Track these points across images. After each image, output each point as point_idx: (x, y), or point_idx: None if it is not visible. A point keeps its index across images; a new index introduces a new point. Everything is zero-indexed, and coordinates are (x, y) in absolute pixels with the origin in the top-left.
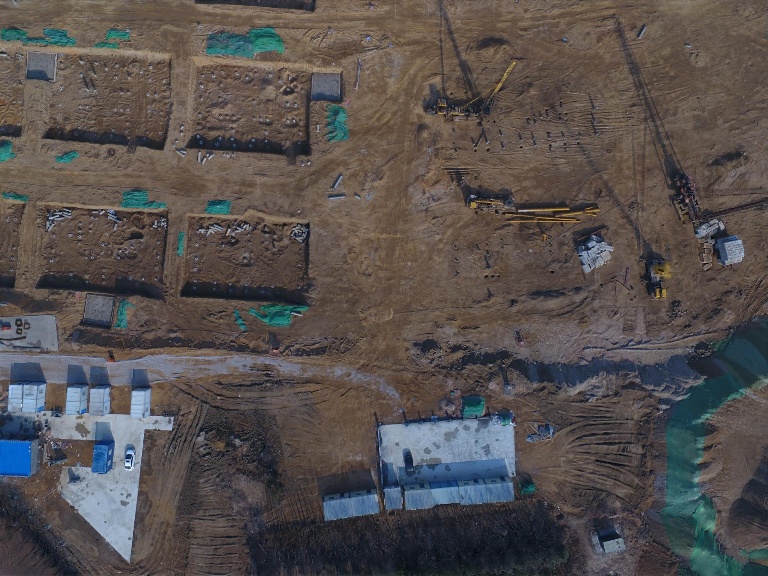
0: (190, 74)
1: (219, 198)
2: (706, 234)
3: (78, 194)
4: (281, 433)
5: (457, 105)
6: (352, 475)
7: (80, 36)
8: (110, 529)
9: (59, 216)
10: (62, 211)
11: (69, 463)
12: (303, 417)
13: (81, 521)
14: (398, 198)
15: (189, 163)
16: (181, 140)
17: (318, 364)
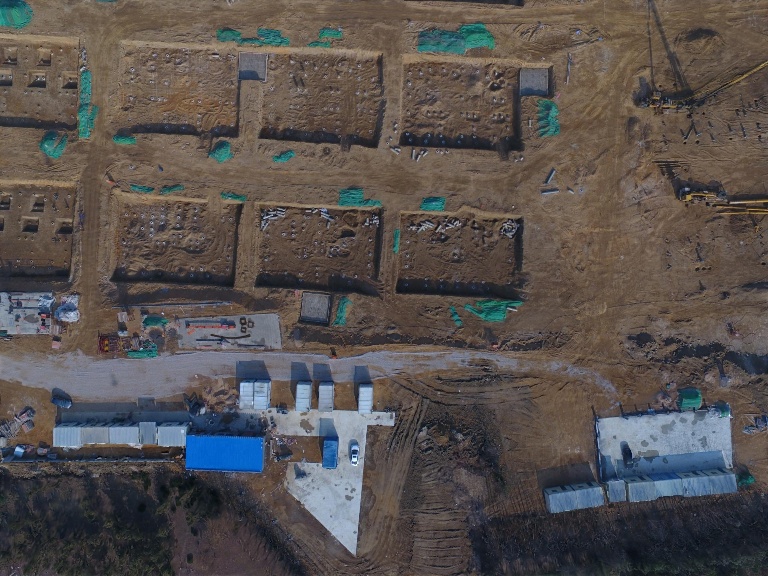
0: (401, 72)
1: (433, 195)
2: None
3: (295, 193)
4: (501, 427)
5: (667, 98)
6: (571, 468)
7: (293, 36)
8: (336, 523)
9: (273, 215)
10: (276, 210)
11: (294, 459)
12: (522, 411)
13: (307, 516)
14: (610, 192)
15: (403, 160)
16: (395, 138)
17: (535, 359)
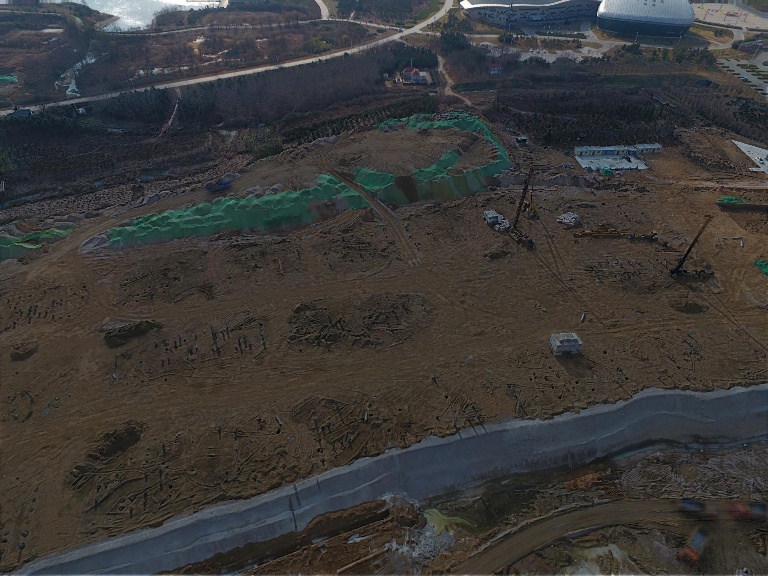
0: None
1: None
2: (507, 222)
3: None
4: None
5: (693, 278)
6: None
7: None
8: (748, 146)
9: None
10: None
11: None
12: None
13: (763, 148)
14: None
15: None
16: None
17: None
